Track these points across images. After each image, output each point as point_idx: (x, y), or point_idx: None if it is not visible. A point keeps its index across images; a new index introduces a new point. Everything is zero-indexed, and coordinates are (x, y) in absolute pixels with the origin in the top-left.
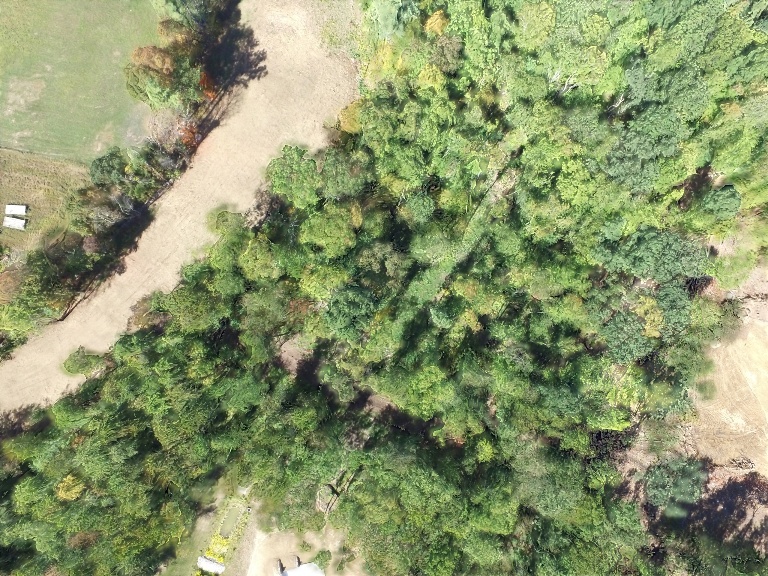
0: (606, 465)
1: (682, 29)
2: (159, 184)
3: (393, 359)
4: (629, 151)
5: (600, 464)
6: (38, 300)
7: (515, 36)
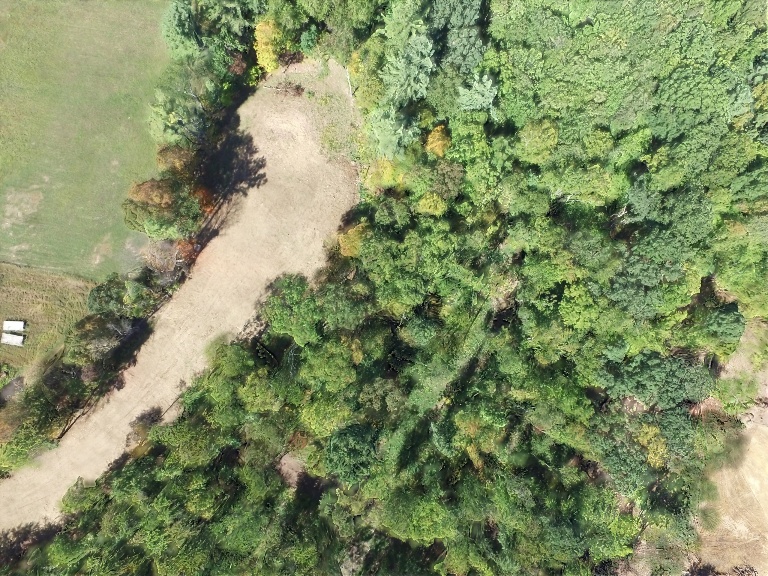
0: (608, 574)
1: (686, 149)
2: (158, 300)
3: (394, 470)
4: (632, 275)
5: (602, 573)
6: (36, 438)
7: (517, 150)
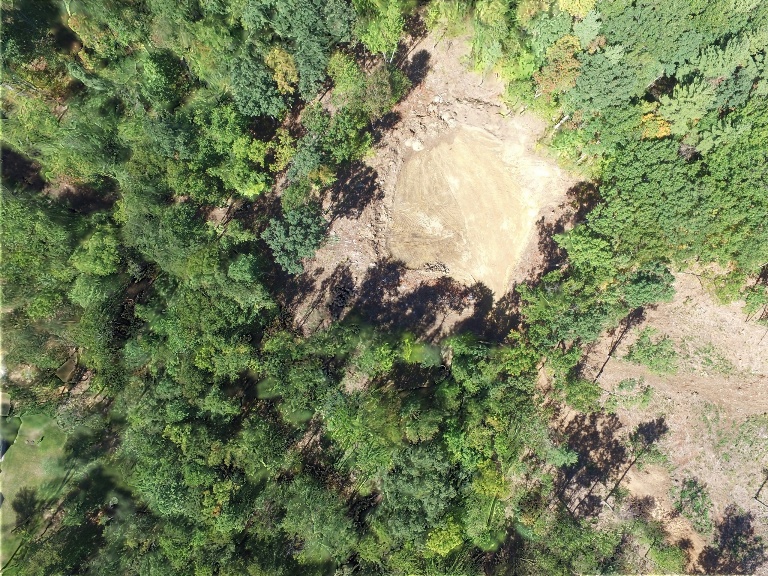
0: (292, 263)
1: None
2: None
3: None
4: None
5: (286, 261)
6: None
7: None
